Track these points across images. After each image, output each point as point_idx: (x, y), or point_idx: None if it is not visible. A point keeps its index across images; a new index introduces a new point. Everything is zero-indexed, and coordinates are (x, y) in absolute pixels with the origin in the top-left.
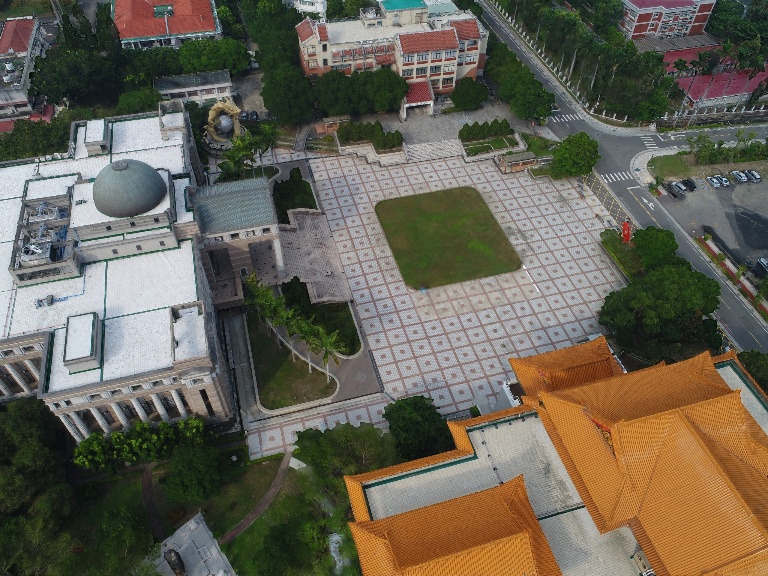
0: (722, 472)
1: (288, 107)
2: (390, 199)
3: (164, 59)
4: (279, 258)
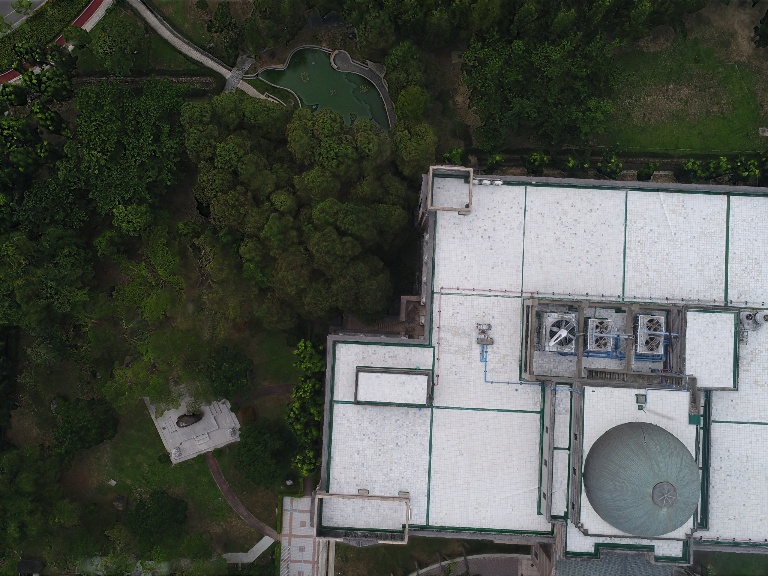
0: None
1: None
2: None
3: None
4: None
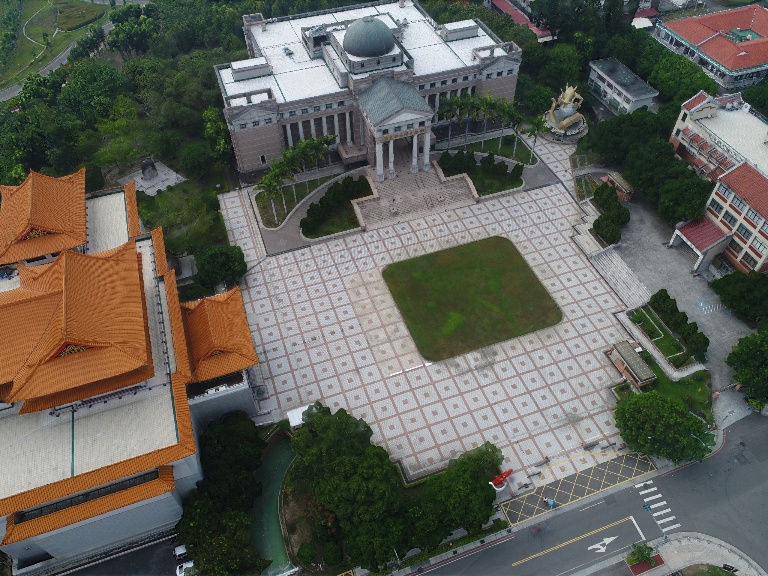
0: (0, 305)
1: (601, 134)
2: (515, 247)
3: (649, 55)
4: (377, 161)
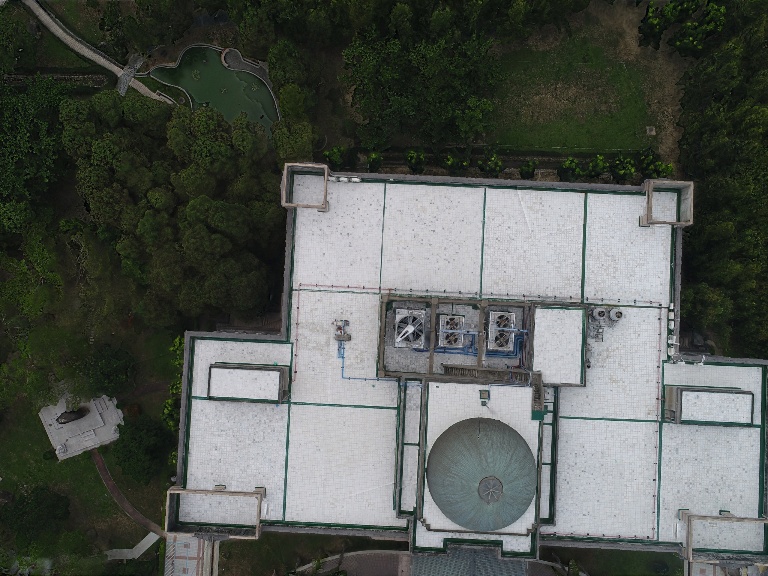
0: None
1: None
2: None
3: None
4: None
